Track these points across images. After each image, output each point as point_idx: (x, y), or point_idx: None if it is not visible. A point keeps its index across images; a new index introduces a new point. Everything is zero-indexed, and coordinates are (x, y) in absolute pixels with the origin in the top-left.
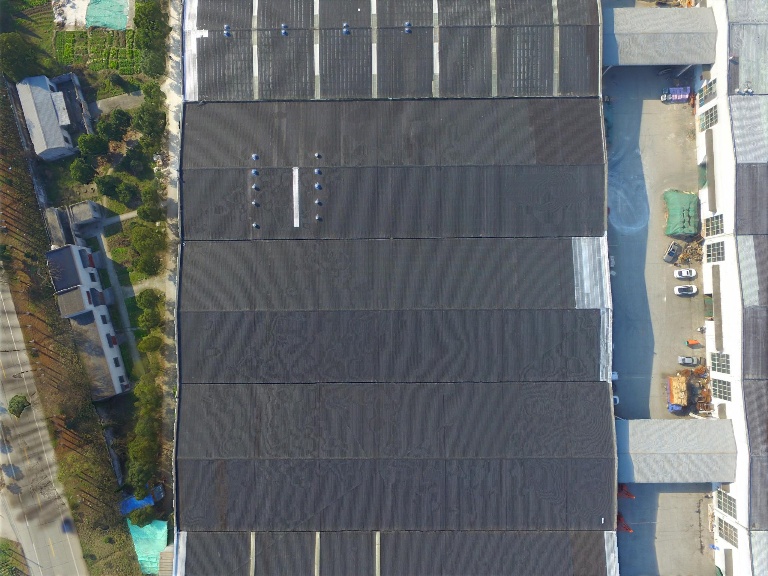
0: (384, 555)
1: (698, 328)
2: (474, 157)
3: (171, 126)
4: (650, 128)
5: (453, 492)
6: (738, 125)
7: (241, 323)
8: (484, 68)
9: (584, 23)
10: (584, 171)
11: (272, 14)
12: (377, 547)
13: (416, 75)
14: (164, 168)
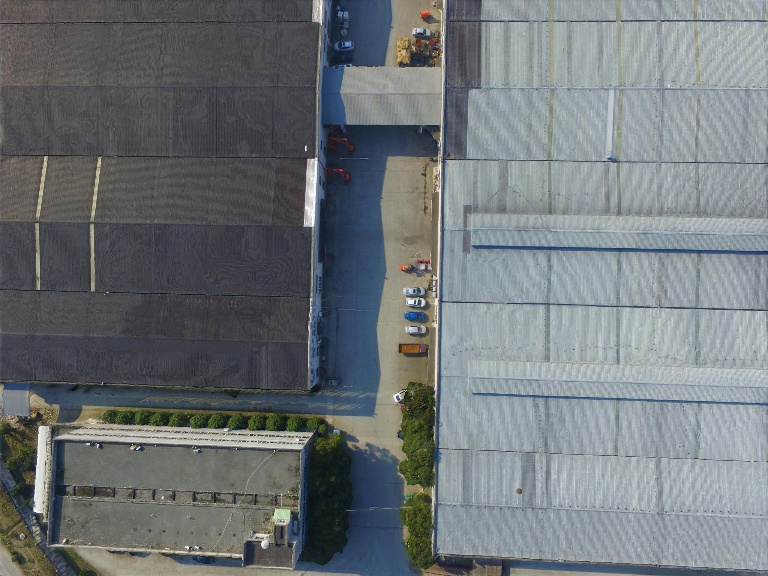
0: (103, 176)
1: None
2: None
3: None
4: None
5: (168, 119)
6: None
7: None
8: None
9: None
10: None
11: None
12: (97, 169)
13: None
14: None
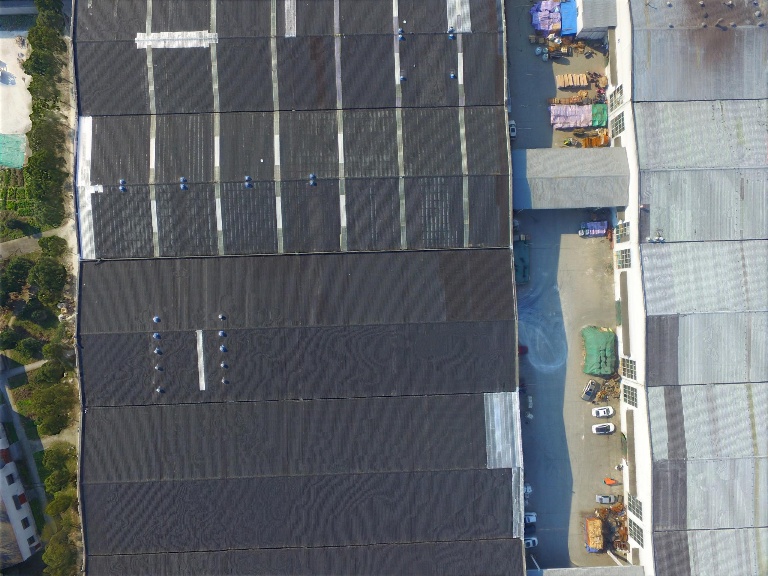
0: None
1: (615, 466)
2: (383, 315)
3: (75, 270)
4: (568, 263)
5: None
6: (649, 275)
7: (147, 493)
8: (393, 220)
9: (494, 172)
10: (495, 327)
11: (170, 167)
12: None
13: (323, 228)
14: (69, 315)
